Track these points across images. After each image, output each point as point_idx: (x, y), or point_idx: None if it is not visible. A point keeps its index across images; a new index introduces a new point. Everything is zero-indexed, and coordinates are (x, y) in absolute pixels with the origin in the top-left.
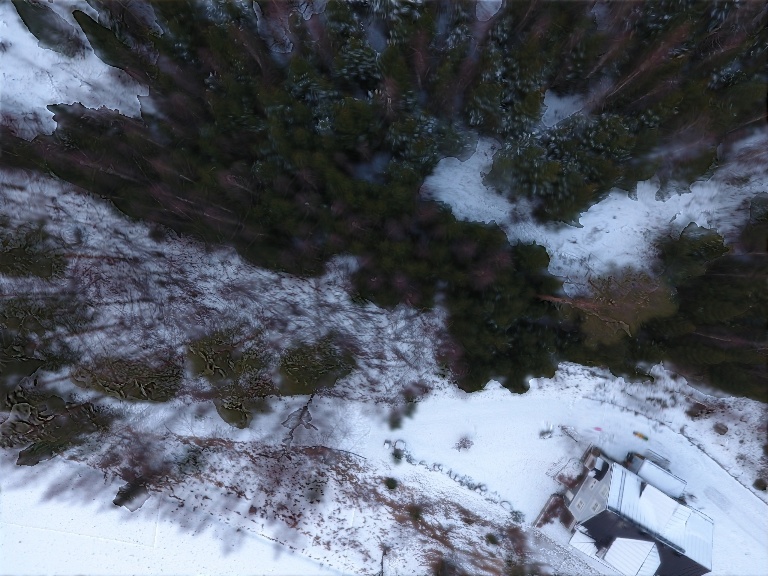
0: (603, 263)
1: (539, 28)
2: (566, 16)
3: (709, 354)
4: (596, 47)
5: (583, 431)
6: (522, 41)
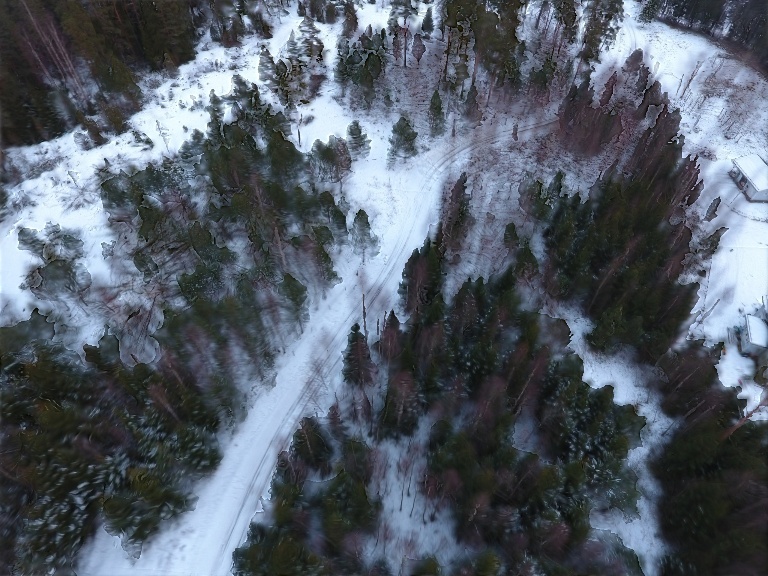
0: (627, 393)
1: (501, 475)
2: (479, 450)
3: (687, 308)
4: (506, 417)
5: (750, 393)
6: (513, 492)
